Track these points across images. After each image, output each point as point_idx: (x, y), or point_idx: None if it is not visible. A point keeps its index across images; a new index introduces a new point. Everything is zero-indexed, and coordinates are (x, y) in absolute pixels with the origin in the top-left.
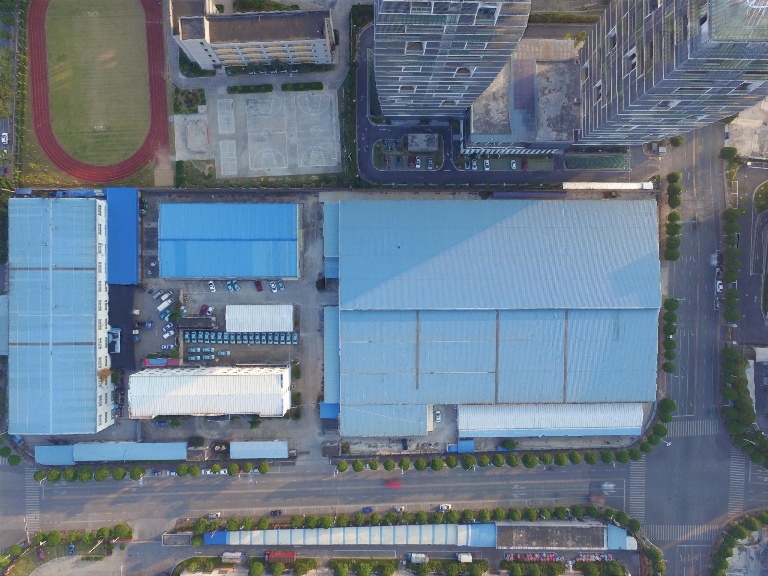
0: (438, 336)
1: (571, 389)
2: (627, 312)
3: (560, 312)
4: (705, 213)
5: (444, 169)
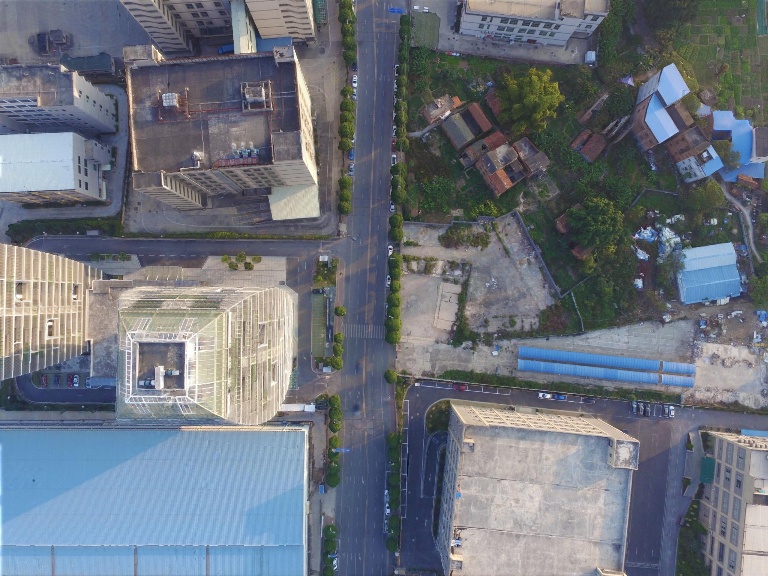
0: (74, 571)
1: None
2: (270, 548)
3: (200, 547)
4: (375, 433)
5: (104, 387)
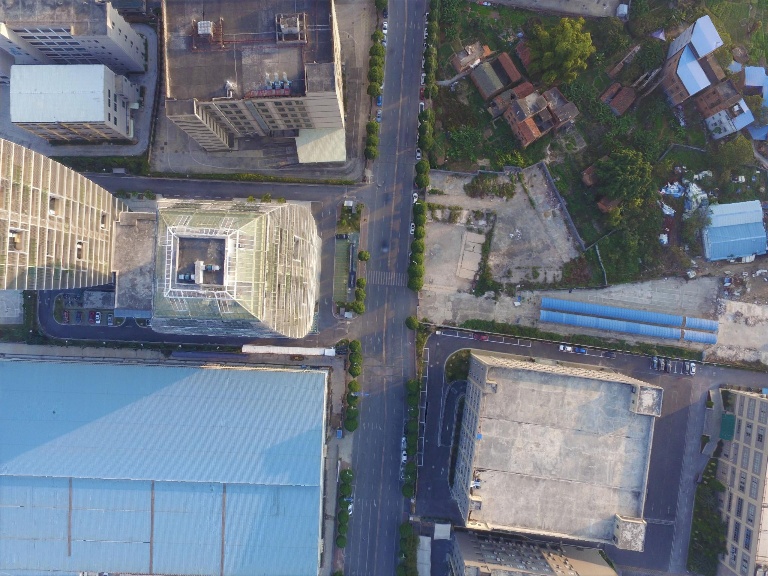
0: (91, 504)
1: (229, 563)
2: (287, 488)
3: (218, 485)
4: (394, 380)
5: (126, 325)
